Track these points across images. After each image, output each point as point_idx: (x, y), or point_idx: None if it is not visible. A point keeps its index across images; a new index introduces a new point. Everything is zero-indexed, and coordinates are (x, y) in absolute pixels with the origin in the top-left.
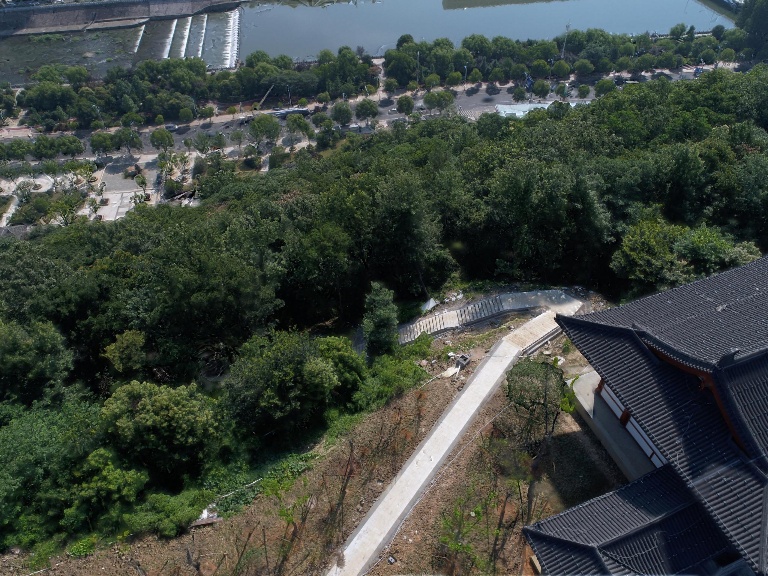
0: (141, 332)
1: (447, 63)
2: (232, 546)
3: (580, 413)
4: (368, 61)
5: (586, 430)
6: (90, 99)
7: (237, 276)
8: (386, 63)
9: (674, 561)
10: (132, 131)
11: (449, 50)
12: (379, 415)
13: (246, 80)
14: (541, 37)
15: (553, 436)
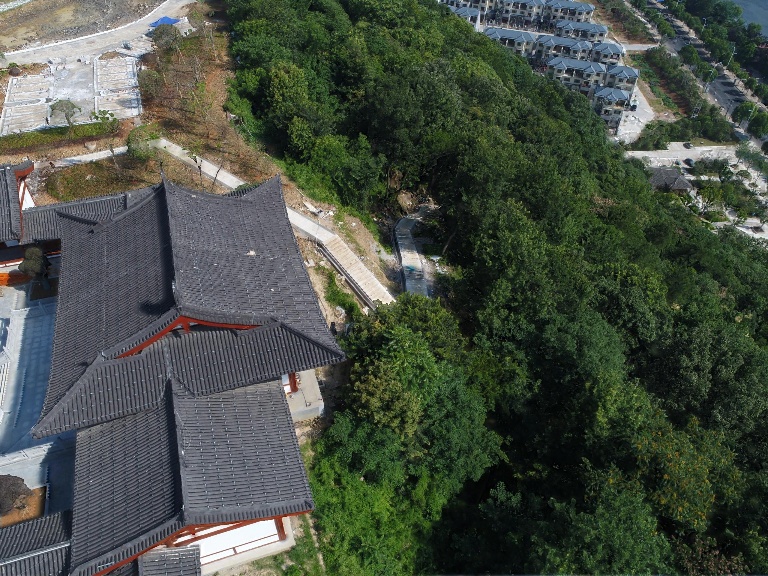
0: None
1: None
2: None
3: None
4: None
5: None
6: None
7: None
8: None
9: None
10: None
11: None
12: None
13: None
14: None
15: None
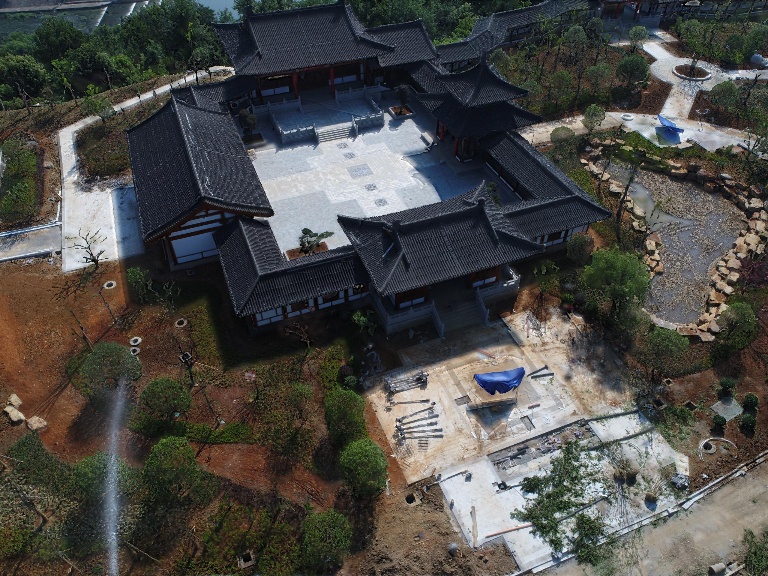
0: None
1: None
2: (46, 108)
3: None
4: None
5: None
6: None
7: None
8: None
9: (228, 96)
10: None
11: None
12: None
13: None
14: None
15: None
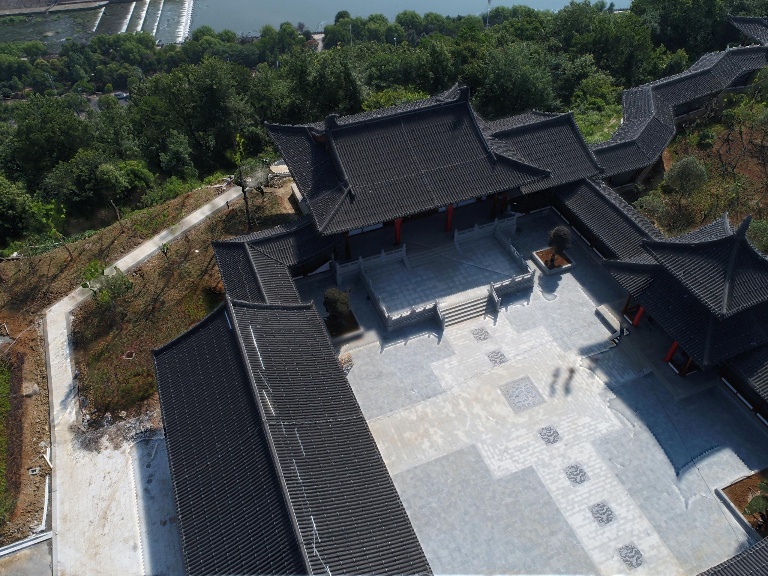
0: (1, 170)
1: (379, 36)
2: (27, 266)
3: (298, 204)
4: (308, 36)
5: (298, 212)
6: (44, 70)
7: (68, 123)
8: (325, 37)
9: (300, 254)
10: (80, 96)
11: (382, 25)
12: (155, 207)
13: (191, 52)
14: (469, 13)
15: (272, 215)
